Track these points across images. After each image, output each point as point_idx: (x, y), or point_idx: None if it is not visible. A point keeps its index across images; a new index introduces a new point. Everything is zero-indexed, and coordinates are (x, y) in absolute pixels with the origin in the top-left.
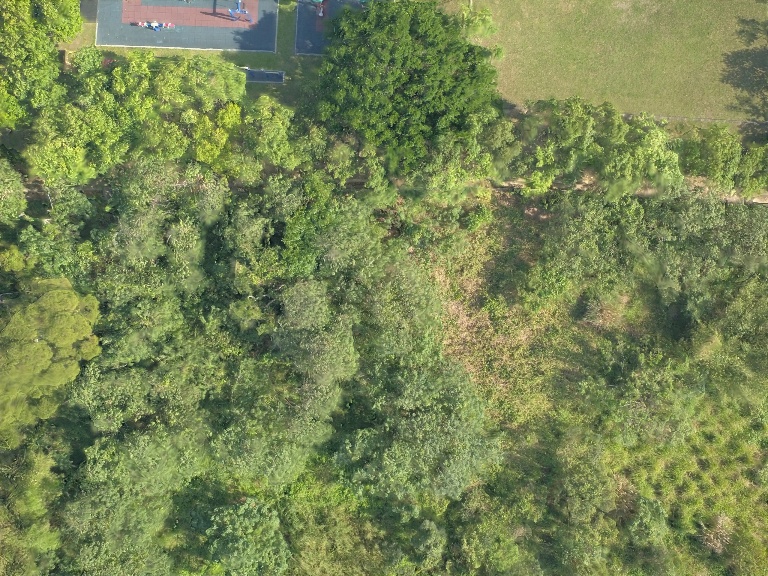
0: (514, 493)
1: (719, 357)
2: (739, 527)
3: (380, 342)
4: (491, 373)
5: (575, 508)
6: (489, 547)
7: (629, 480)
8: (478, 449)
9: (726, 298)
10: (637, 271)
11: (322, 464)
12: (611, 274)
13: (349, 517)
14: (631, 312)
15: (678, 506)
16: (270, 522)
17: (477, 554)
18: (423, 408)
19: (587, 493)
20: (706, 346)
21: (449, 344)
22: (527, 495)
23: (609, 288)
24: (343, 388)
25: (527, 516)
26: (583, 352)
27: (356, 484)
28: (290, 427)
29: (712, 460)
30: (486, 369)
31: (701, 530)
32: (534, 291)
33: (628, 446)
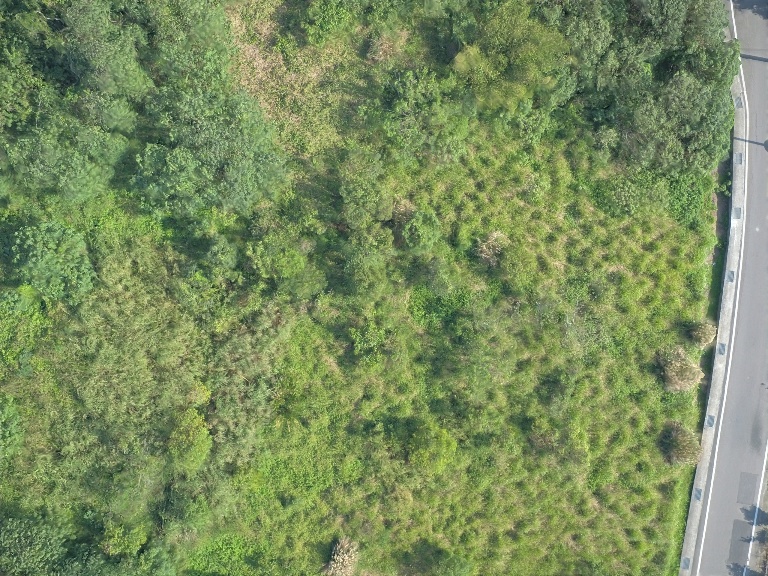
0: (301, 210)
1: (482, 73)
2: (514, 243)
3: (162, 57)
4: (284, 109)
5: (349, 212)
6: (273, 254)
7: (413, 203)
8: (262, 165)
9: (488, 20)
10: (418, 12)
11: (129, 197)
12: (385, 4)
13: (155, 247)
14: (411, 48)
15: (457, 225)
16: (74, 242)
17: (264, 263)
18: (203, 117)
19: (361, 199)
20: (463, 55)
21: (246, 84)
22: (312, 211)
23: (384, 18)
24: (137, 111)
25: (311, 228)
26: (368, 86)
27: (155, 207)
28: (78, 134)
29: (488, 182)
30: (280, 105)
31: (477, 244)
32: (315, 22)
33: (411, 171)
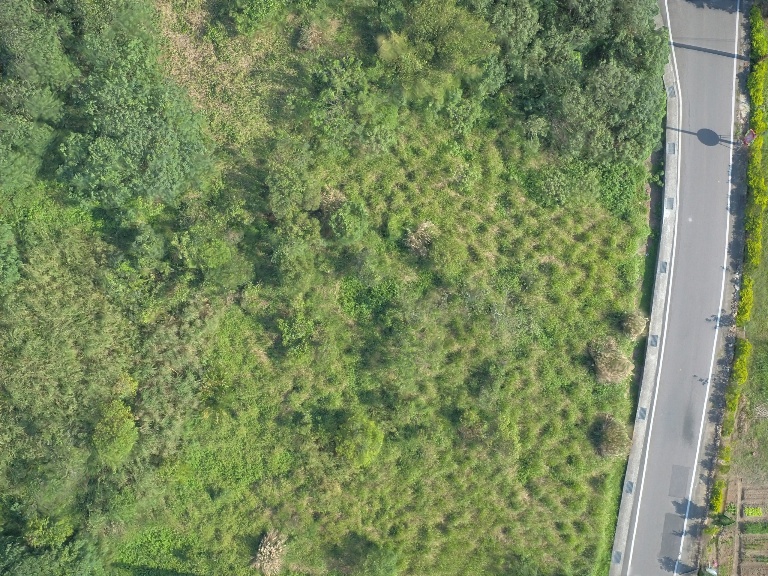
0: (228, 200)
1: (409, 62)
2: (445, 234)
3: (85, 45)
4: (215, 98)
5: (275, 202)
6: (199, 244)
7: (343, 194)
8: (189, 154)
9: (416, 8)
10: (349, 1)
11: (59, 188)
12: None
13: (85, 238)
14: (342, 37)
15: (387, 215)
16: (1, 233)
17: (190, 253)
18: (126, 106)
19: (286, 188)
20: (388, 44)
21: (177, 74)
22: (239, 201)
23: (313, 7)
24: (63, 101)
25: (238, 218)
26: (298, 75)
27: (82, 197)
28: None
29: (418, 172)
30: (210, 95)
31: (407, 235)
32: (243, 11)
33: (341, 161)
